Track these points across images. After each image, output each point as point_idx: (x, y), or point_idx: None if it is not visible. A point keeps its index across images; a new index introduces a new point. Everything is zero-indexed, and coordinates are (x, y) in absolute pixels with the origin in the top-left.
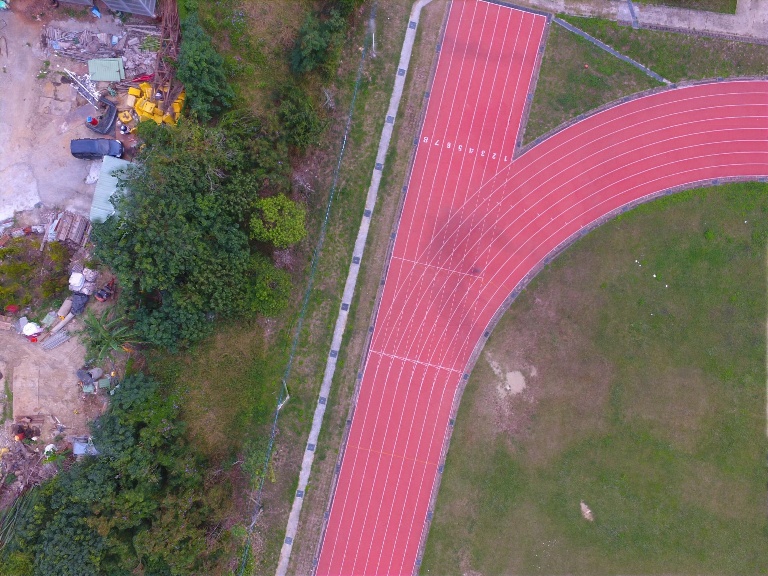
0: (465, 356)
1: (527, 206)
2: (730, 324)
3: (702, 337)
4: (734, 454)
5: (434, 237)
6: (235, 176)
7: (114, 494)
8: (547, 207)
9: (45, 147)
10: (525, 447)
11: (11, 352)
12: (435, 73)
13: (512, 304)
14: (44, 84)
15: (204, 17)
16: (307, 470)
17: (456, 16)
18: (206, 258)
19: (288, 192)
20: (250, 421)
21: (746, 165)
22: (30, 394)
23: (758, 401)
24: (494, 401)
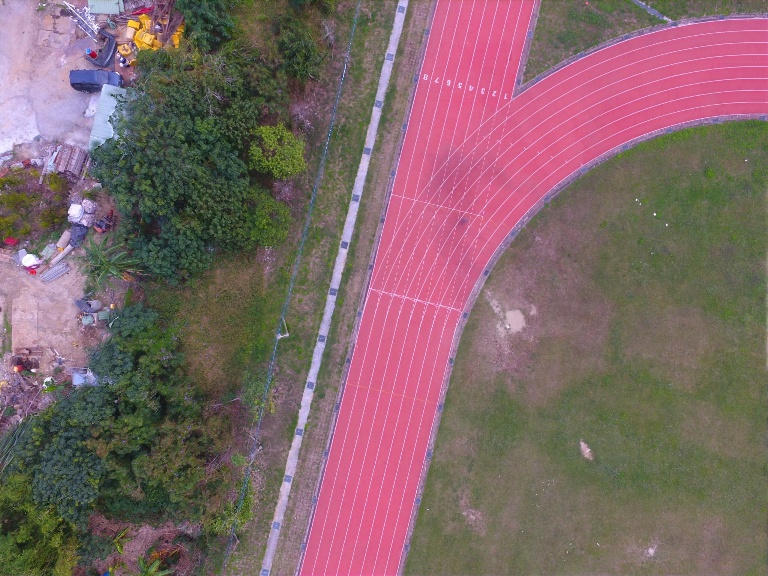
0: (465, 295)
1: (527, 144)
2: (730, 263)
3: (702, 276)
4: (734, 393)
5: (434, 175)
6: (234, 102)
7: (113, 418)
8: (547, 145)
9: (44, 80)
10: (525, 386)
11: (10, 284)
12: (435, 10)
13: (512, 242)
14: (43, 17)
15: None
16: (306, 408)
17: None
18: (205, 182)
19: (287, 125)
20: (249, 359)
21: (747, 103)
22: (29, 326)
23: (758, 340)
24: (494, 340)
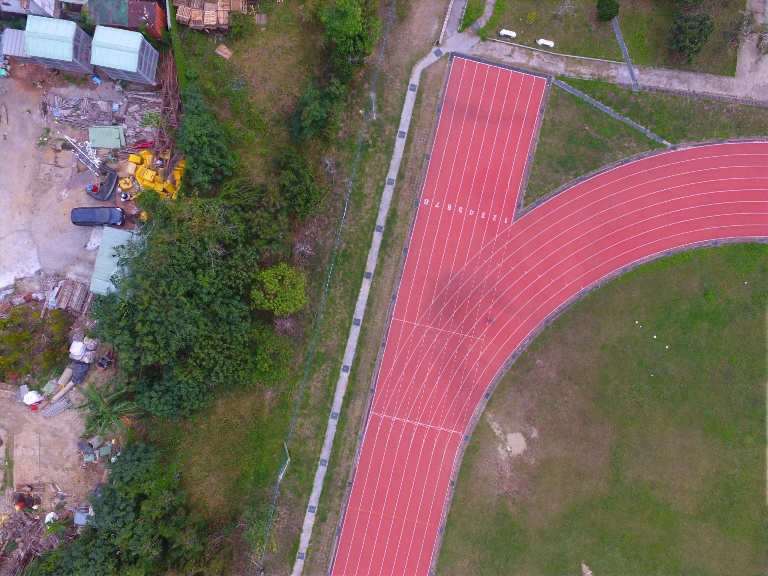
0: (466, 417)
1: (527, 267)
2: (730, 385)
3: (703, 398)
4: (735, 515)
5: (435, 299)
6: (236, 250)
7: (115, 570)
8: (547, 268)
9: (45, 214)
10: (526, 508)
11: (12, 420)
12: (435, 135)
13: (513, 365)
14: (44, 151)
15: (204, 84)
16: (308, 532)
17: (456, 78)
18: (207, 334)
19: (289, 258)
20: (251, 484)
21: (746, 226)
22: (31, 462)
23: (759, 462)
24: (495, 462)
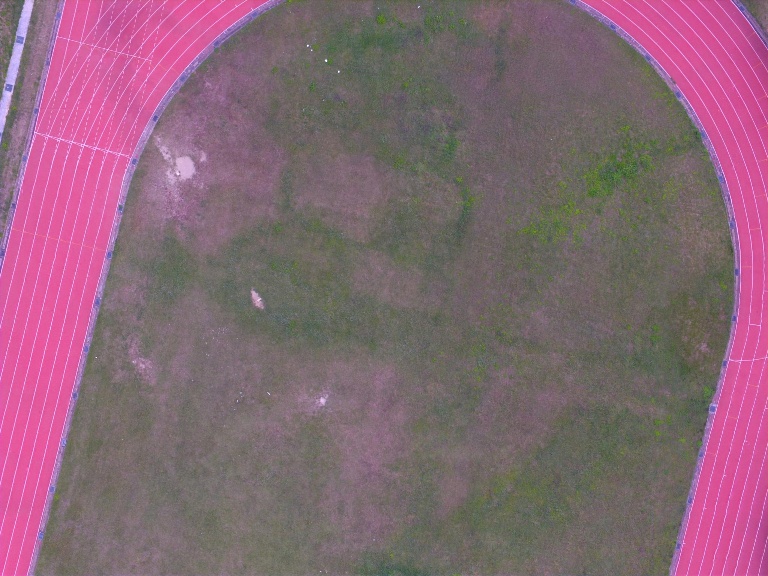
0: (133, 140)
1: None
2: (403, 111)
3: (375, 124)
4: (407, 243)
5: (100, 17)
6: None
7: None
8: None
9: None
10: (194, 233)
11: None
12: None
13: (181, 88)
14: None
15: None
16: None
17: None
18: None
19: None
20: None
21: None
22: None
23: (431, 190)
24: (163, 187)
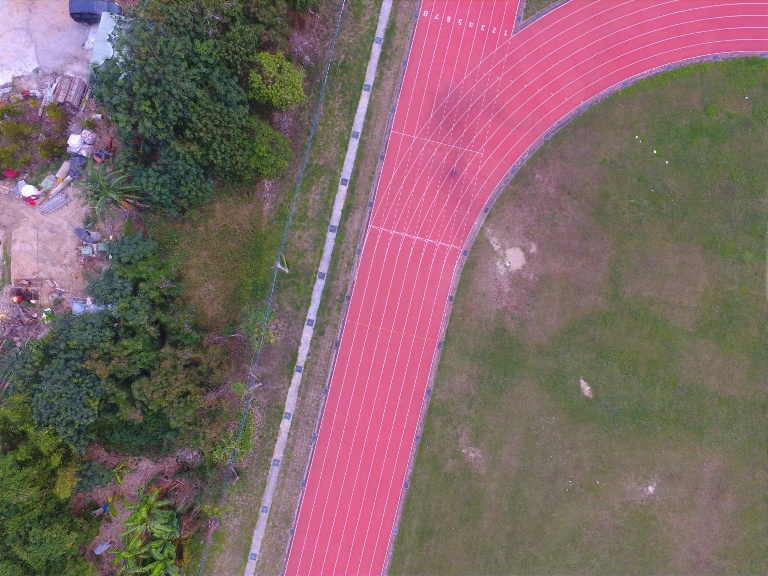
0: (465, 232)
1: (527, 81)
2: (730, 201)
3: (702, 214)
4: (734, 331)
5: (434, 112)
6: (234, 26)
7: (112, 342)
8: (547, 82)
9: (43, 12)
10: (525, 323)
11: (9, 216)
12: None
13: (512, 180)
14: None
15: None
16: (306, 345)
17: None
18: (205, 105)
19: (287, 58)
20: (249, 295)
21: (747, 40)
22: (28, 258)
23: (758, 278)
24: (494, 277)
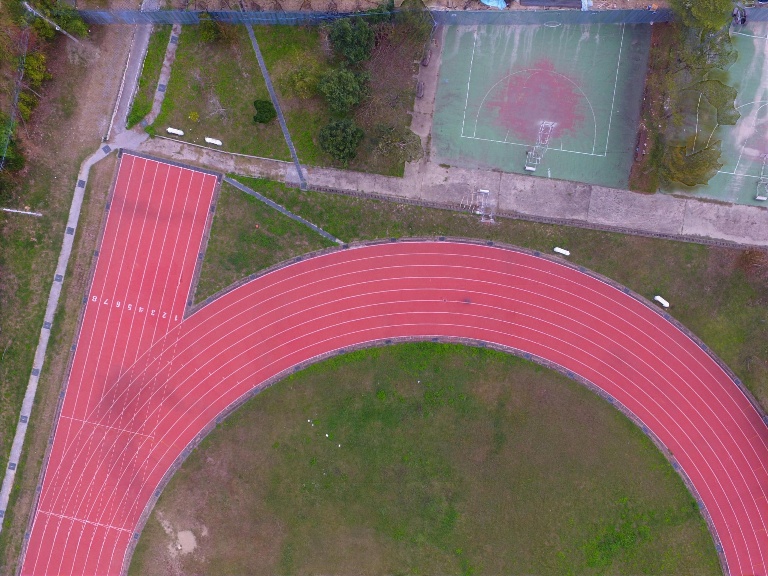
0: (135, 515)
1: (198, 365)
2: (403, 483)
3: (375, 496)
4: None
5: (104, 396)
6: None
7: None
8: (219, 366)
9: None
10: None
11: None
12: (104, 232)
13: (183, 463)
14: None
15: None
16: None
17: (125, 175)
18: None
19: None
20: None
21: (419, 325)
22: None
23: (431, 560)
24: (165, 560)
